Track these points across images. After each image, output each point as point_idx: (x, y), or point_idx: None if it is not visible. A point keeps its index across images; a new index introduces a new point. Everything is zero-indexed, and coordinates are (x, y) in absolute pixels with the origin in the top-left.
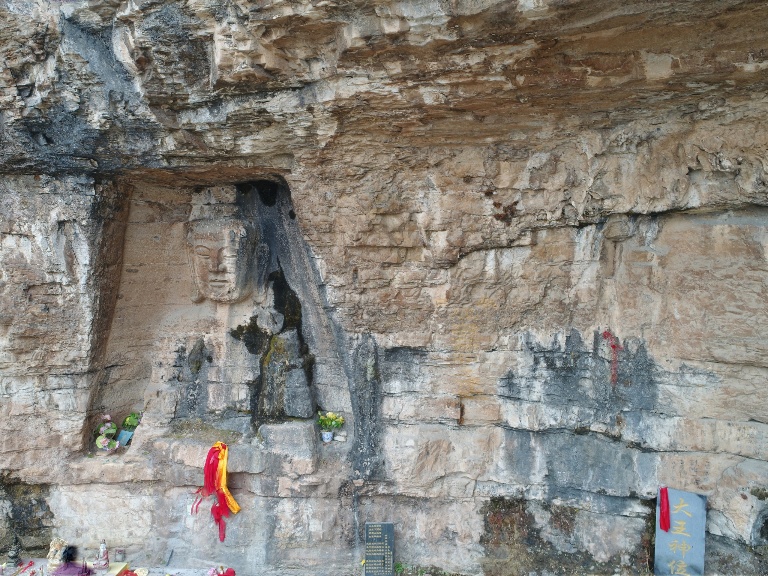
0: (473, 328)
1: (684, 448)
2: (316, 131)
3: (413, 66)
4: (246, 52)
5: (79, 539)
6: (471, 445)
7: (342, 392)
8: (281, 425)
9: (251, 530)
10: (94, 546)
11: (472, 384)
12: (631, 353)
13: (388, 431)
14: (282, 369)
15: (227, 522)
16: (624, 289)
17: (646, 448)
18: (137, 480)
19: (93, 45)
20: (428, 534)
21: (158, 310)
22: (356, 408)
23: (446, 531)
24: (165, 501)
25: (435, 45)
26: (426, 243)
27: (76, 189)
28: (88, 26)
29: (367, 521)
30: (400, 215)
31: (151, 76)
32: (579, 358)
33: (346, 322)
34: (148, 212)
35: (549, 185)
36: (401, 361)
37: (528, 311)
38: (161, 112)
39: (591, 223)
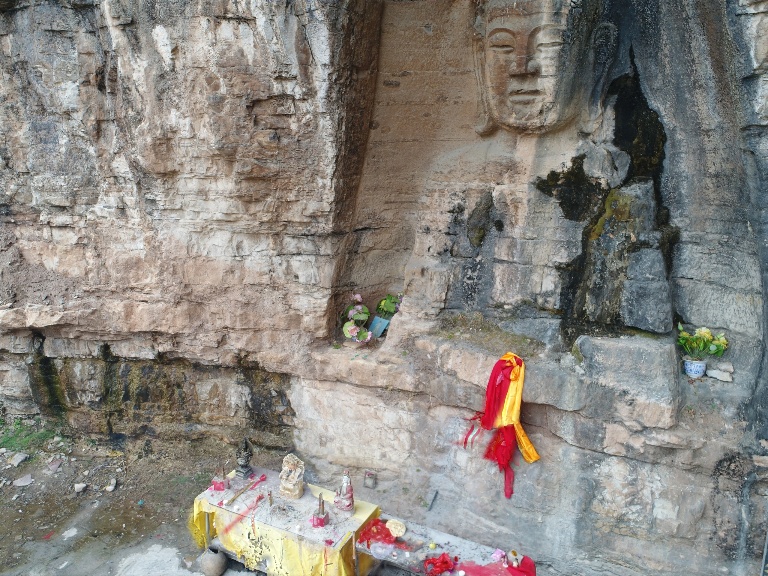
0: None
1: None
2: None
3: None
4: None
5: (323, 448)
6: None
7: (731, 295)
8: (617, 341)
9: (554, 493)
10: (340, 461)
11: None
12: None
13: None
14: (623, 247)
15: (516, 471)
16: None
17: None
18: (393, 387)
19: None
20: None
21: (426, 149)
22: None
23: None
24: (429, 422)
25: None
26: None
27: None
28: None
29: (765, 524)
30: None
31: None
32: None
33: None
34: None
35: None
36: None
37: None
38: None
39: None
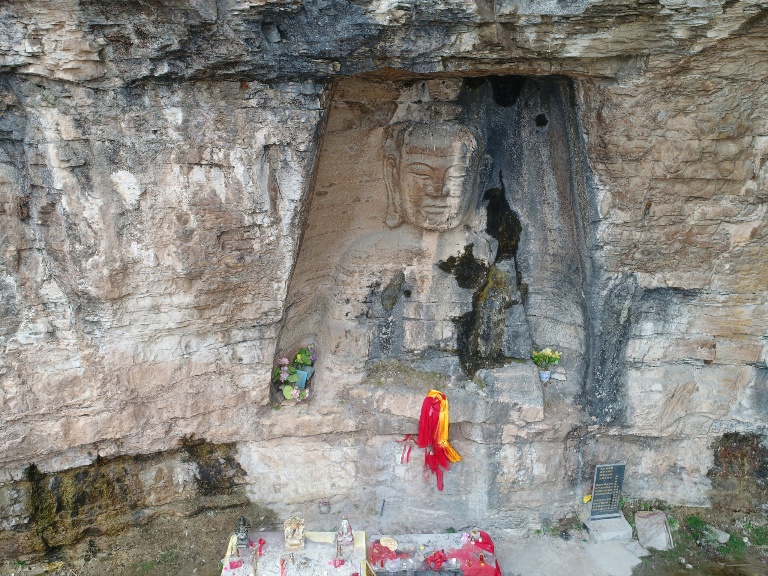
0: (765, 268)
1: None
2: (706, 32)
3: None
4: None
5: (278, 494)
6: (715, 384)
7: (561, 326)
8: (507, 371)
9: (473, 478)
10: (296, 501)
11: (739, 326)
12: None
13: (629, 374)
14: (501, 306)
15: (443, 470)
16: None
17: None
18: (336, 431)
19: None
20: (654, 470)
21: (341, 236)
22: (597, 352)
23: (674, 467)
24: (368, 450)
25: None
26: (756, 174)
27: (297, 101)
28: None
29: (591, 460)
30: (740, 140)
31: None
32: None
33: (611, 262)
34: (347, 116)
35: None
36: (655, 299)
37: None
38: None
39: None
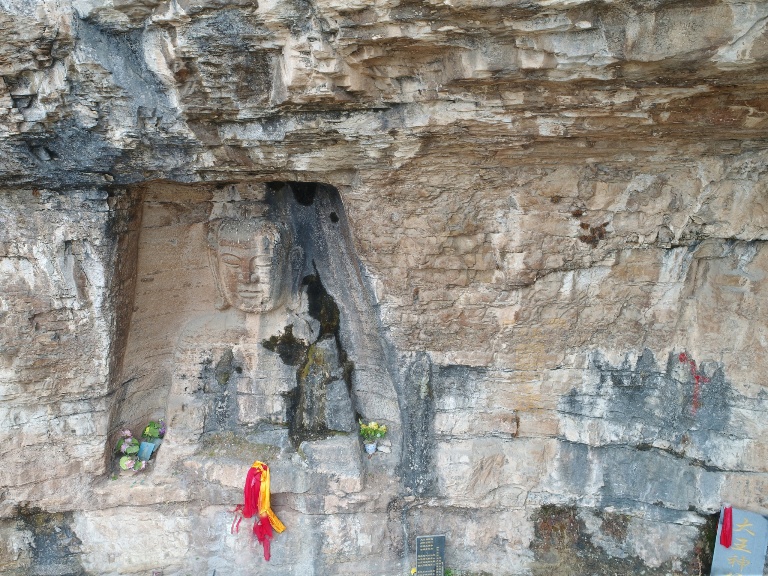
0: (539, 347)
1: (751, 468)
2: (393, 153)
3: (539, 98)
4: (327, 73)
5: (112, 564)
6: (524, 457)
7: (385, 401)
8: (325, 443)
9: (298, 548)
10: (129, 570)
11: (532, 401)
12: (707, 376)
13: (440, 446)
14: (322, 382)
15: (271, 540)
16: (708, 313)
17: (711, 466)
18: (169, 501)
19: (116, 50)
20: (478, 542)
21: (176, 317)
22: (406, 425)
23: (496, 538)
24: (201, 520)
25: (577, 80)
26: (500, 265)
27: (86, 205)
28: (110, 27)
29: (416, 532)
30: (474, 236)
31: (193, 89)
32: (648, 377)
33: (400, 341)
34: (163, 214)
35: (648, 208)
36: (455, 376)
37: (599, 330)
38: (200, 127)
39: (684, 245)
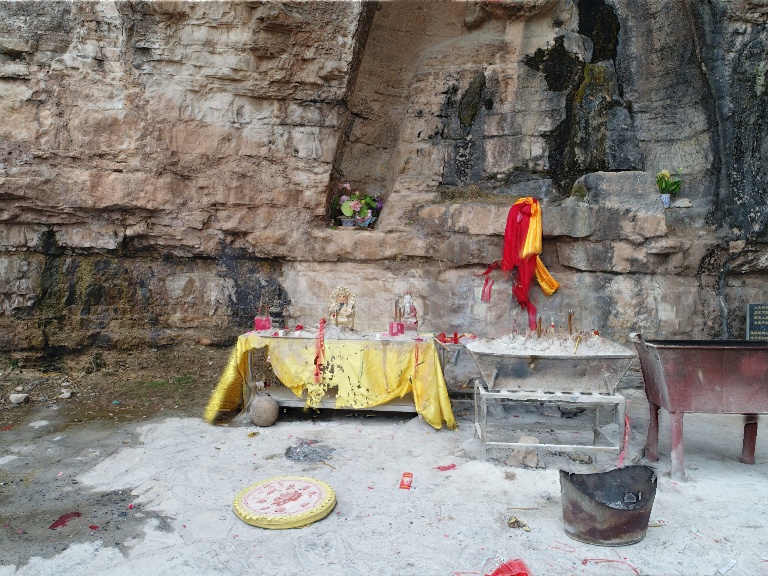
0: None
1: None
2: None
3: None
4: None
5: None
6: None
7: (677, 145)
8: None
9: (576, 315)
10: None
11: None
12: None
13: None
14: (601, 106)
15: (537, 308)
16: None
17: None
18: (402, 256)
19: None
20: None
21: (415, 42)
22: (730, 142)
23: None
24: (440, 286)
25: None
26: None
27: None
28: None
29: (738, 309)
30: None
31: None
32: None
33: (736, 2)
34: None
35: None
36: None
37: None
38: None
39: None
